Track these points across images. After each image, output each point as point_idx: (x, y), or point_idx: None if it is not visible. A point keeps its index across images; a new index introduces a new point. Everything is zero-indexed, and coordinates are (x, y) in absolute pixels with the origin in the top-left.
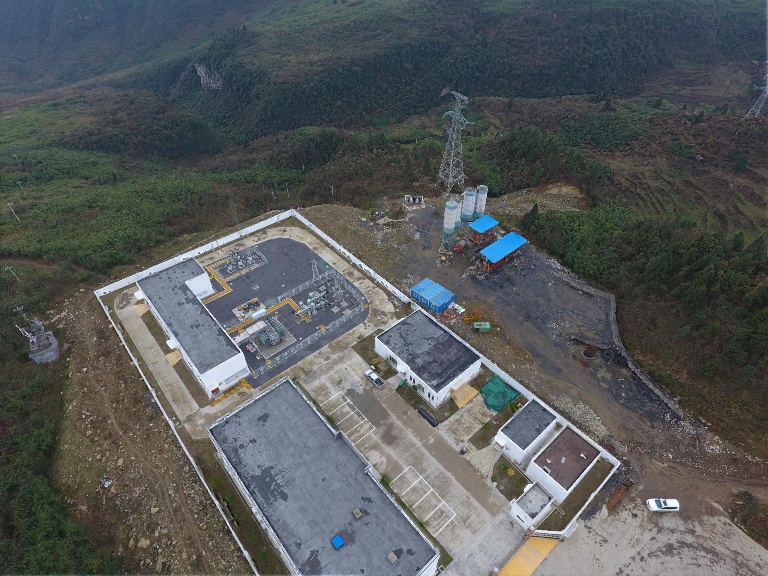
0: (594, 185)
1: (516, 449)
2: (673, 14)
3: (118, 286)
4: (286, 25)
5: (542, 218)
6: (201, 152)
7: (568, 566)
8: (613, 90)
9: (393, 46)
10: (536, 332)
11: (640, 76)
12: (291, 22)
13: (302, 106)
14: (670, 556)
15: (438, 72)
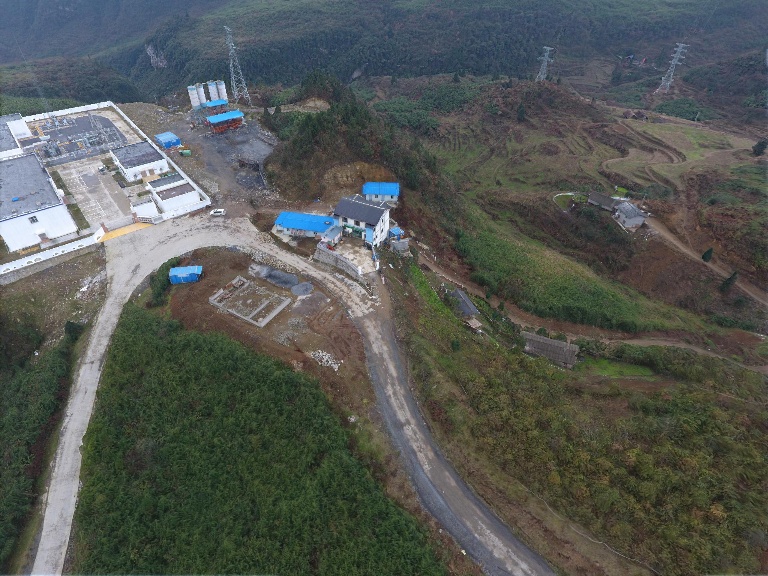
0: None
1: (152, 190)
2: (553, 15)
3: None
4: (225, 14)
5: (283, 114)
6: None
7: (150, 232)
8: None
9: (309, 33)
10: (219, 157)
11: (523, 66)
12: (231, 12)
13: None
14: (205, 229)
15: None
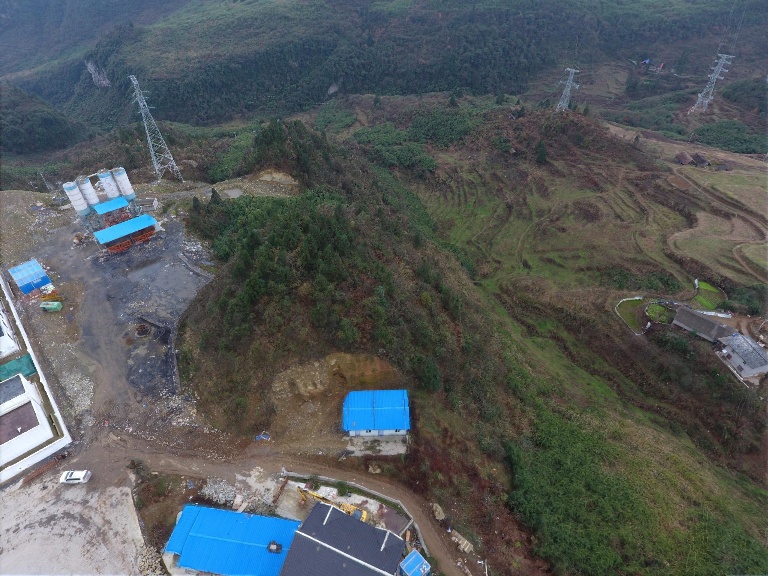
0: (309, 172)
1: None
2: (556, 15)
3: None
4: (176, 22)
5: (223, 203)
6: (57, 148)
7: None
8: (495, 89)
9: (275, 44)
10: (107, 311)
11: (523, 75)
12: (183, 20)
13: (178, 103)
14: (44, 527)
15: (323, 70)
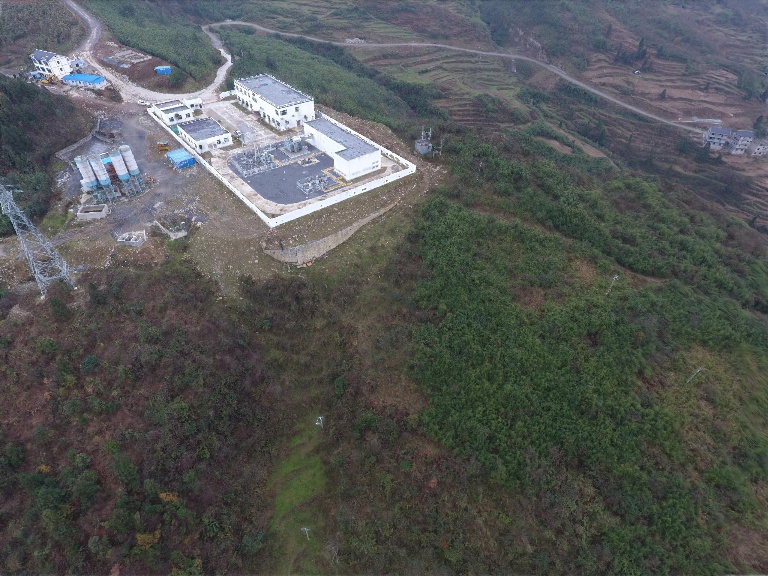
0: None
1: None
2: None
3: (405, 173)
4: None
5: None
6: None
7: None
8: None
9: None
10: (131, 144)
11: None
12: None
13: None
14: None
15: None
